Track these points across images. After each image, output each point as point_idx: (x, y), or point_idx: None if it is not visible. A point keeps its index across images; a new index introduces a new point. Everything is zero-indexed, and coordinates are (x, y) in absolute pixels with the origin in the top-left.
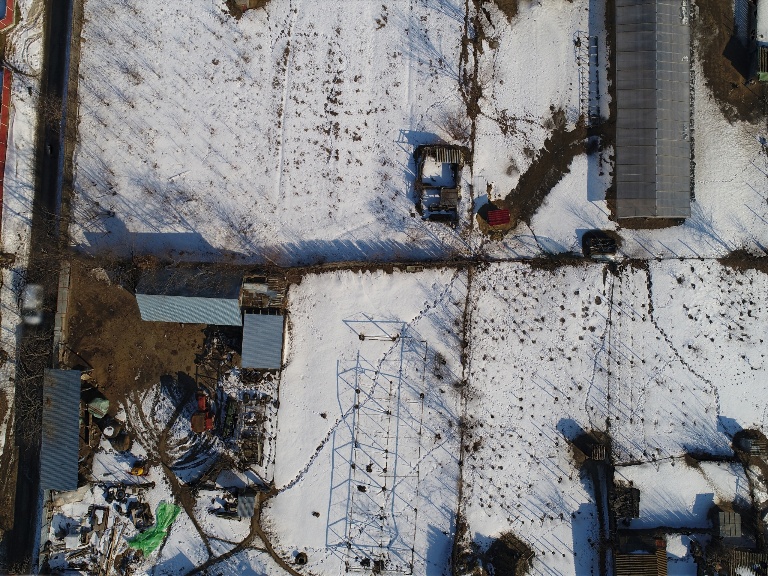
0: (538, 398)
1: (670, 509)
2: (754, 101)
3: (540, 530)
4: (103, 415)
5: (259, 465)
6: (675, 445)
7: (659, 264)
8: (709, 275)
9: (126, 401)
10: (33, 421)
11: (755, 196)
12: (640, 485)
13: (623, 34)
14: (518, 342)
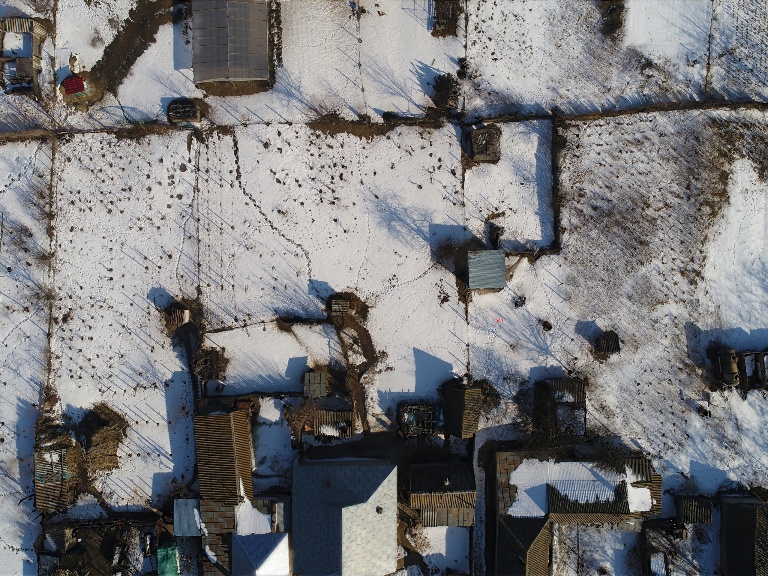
0: (128, 268)
1: (262, 374)
2: None
3: (133, 400)
4: None
5: None
6: (265, 309)
7: (245, 129)
8: (297, 139)
9: None
10: None
11: (346, 60)
12: (232, 351)
13: None
14: (106, 213)
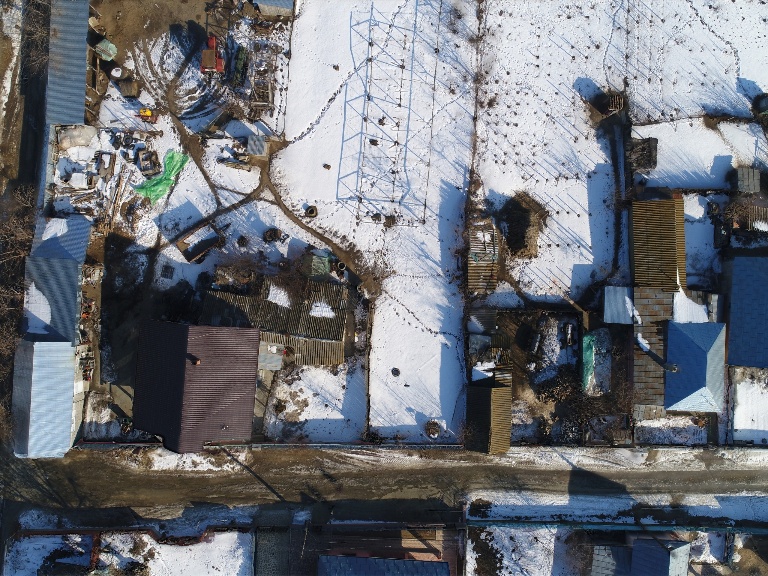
0: (555, 56)
1: (687, 170)
2: None
3: (555, 189)
4: (111, 57)
5: (269, 116)
6: (694, 105)
7: None
8: None
9: (134, 50)
10: (40, 45)
11: None
12: (657, 145)
13: None
14: None
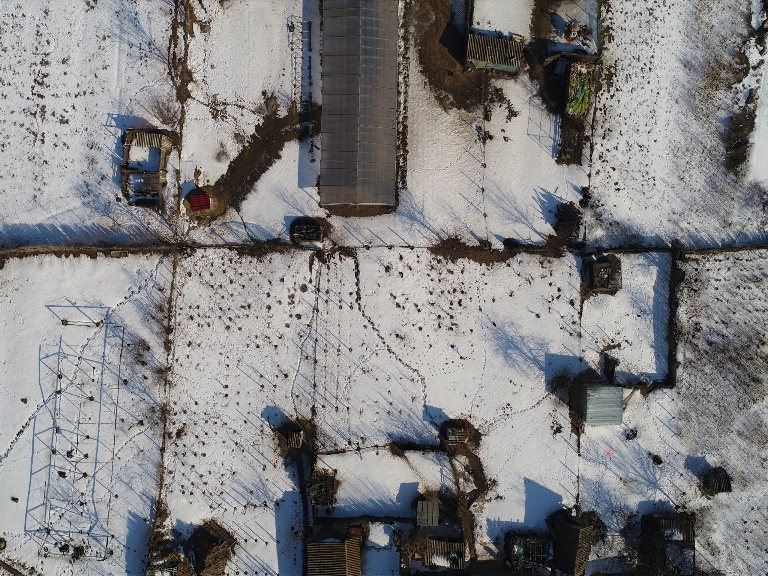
0: (243, 385)
1: (373, 498)
2: (471, 89)
3: (243, 517)
4: None
5: None
6: (379, 434)
7: (367, 252)
8: (418, 264)
9: None
10: None
11: (470, 185)
12: (344, 473)
13: (330, 19)
14: (224, 329)
